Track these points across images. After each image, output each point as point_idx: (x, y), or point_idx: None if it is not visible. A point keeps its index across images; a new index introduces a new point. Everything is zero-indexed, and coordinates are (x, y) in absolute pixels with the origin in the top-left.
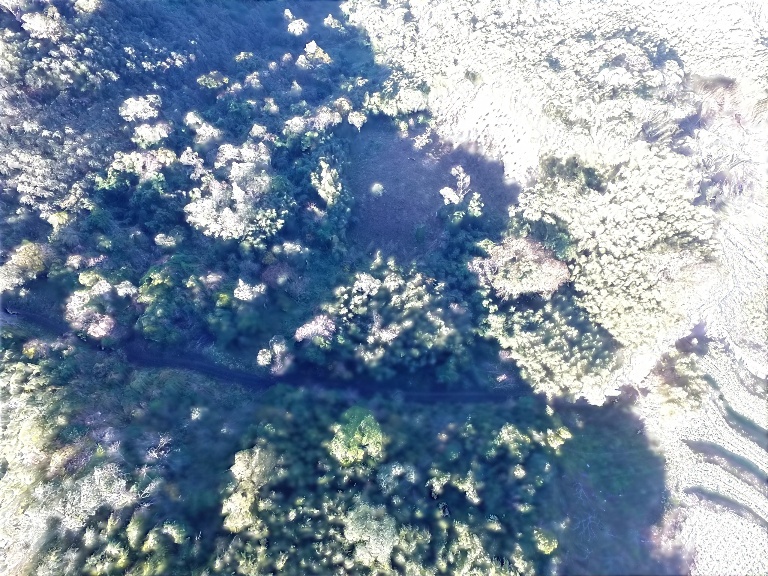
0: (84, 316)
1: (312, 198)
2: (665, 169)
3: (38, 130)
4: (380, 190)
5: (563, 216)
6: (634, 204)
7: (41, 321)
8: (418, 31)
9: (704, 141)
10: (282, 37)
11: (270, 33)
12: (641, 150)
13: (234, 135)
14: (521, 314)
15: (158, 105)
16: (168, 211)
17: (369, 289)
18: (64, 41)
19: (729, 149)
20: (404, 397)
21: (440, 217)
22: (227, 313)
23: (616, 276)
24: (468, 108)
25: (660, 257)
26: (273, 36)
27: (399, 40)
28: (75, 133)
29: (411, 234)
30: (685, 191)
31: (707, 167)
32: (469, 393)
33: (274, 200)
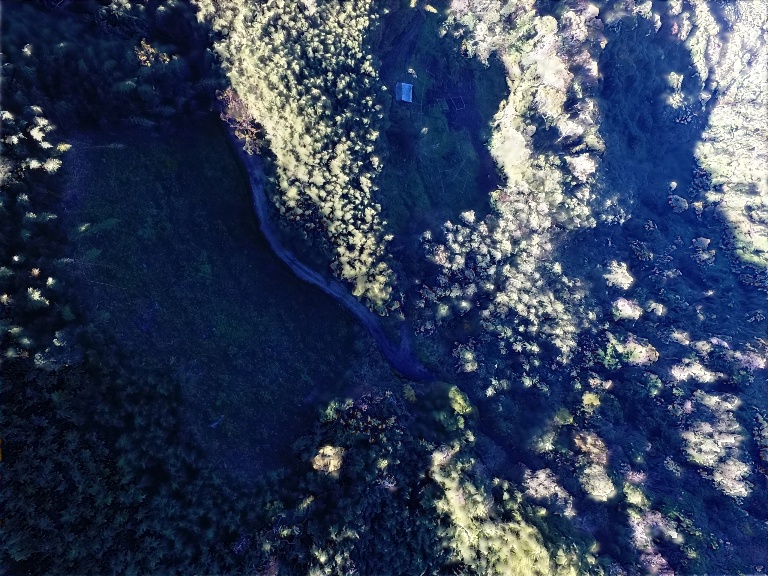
0: None
1: None
2: None
3: (560, 274)
4: None
5: None
6: None
7: None
8: None
9: None
10: (654, 201)
11: (647, 193)
12: None
13: None
14: None
15: None
16: None
17: None
18: None
19: None
20: None
21: None
22: None
23: None
24: None
25: None
26: (647, 196)
27: None
28: None
29: None
30: None
31: None
32: None
33: (738, 452)
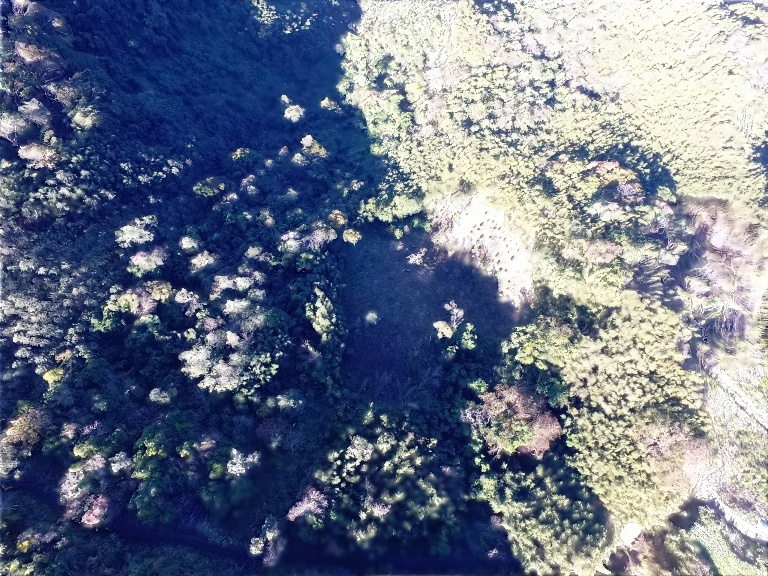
0: (78, 500)
1: (307, 328)
2: (656, 324)
3: (34, 268)
4: (374, 319)
5: (555, 362)
6: (625, 358)
7: (36, 490)
8: (414, 120)
9: (695, 290)
10: (279, 121)
11: (267, 118)
12: (632, 300)
13: (230, 247)
14: (513, 475)
15: (154, 226)
16: (163, 355)
17: (362, 456)
18: (61, 165)
19: (719, 301)
20: (396, 566)
21: (434, 342)
22: (220, 487)
23: (607, 438)
24: (463, 215)
25: (650, 430)
26: (270, 120)
27: (395, 132)
28: (71, 268)
29: (405, 363)
30: (675, 352)
31: (697, 319)
32: (461, 557)
33: (268, 340)
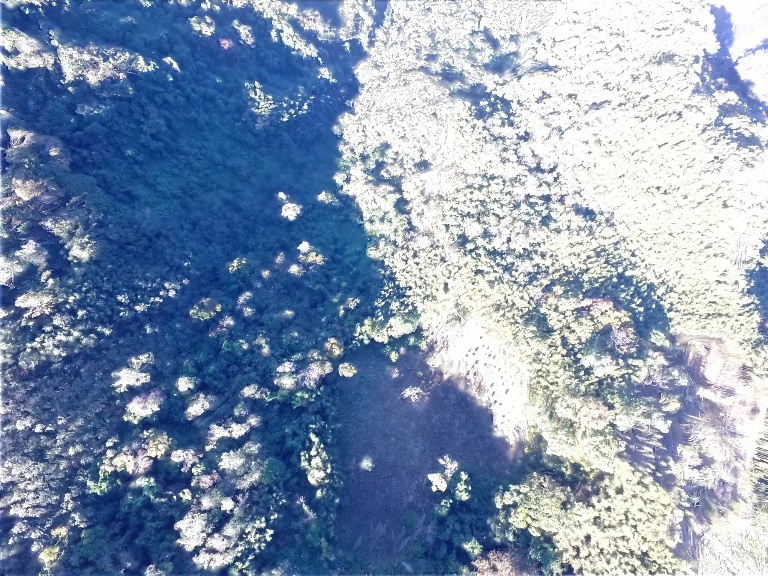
0: None
1: (302, 478)
2: (647, 501)
3: (31, 426)
4: (369, 467)
5: (548, 530)
6: (617, 534)
7: None
8: (410, 222)
9: (687, 459)
10: (276, 217)
11: (264, 214)
12: (624, 471)
13: (226, 376)
14: None
15: (150, 363)
16: (159, 519)
17: None
18: (57, 307)
19: (711, 474)
20: None
21: None
22: None
23: None
24: (458, 336)
25: None
26: (267, 216)
27: (391, 237)
28: (68, 422)
29: (400, 510)
30: (666, 537)
31: (689, 494)
32: None
33: (263, 500)
